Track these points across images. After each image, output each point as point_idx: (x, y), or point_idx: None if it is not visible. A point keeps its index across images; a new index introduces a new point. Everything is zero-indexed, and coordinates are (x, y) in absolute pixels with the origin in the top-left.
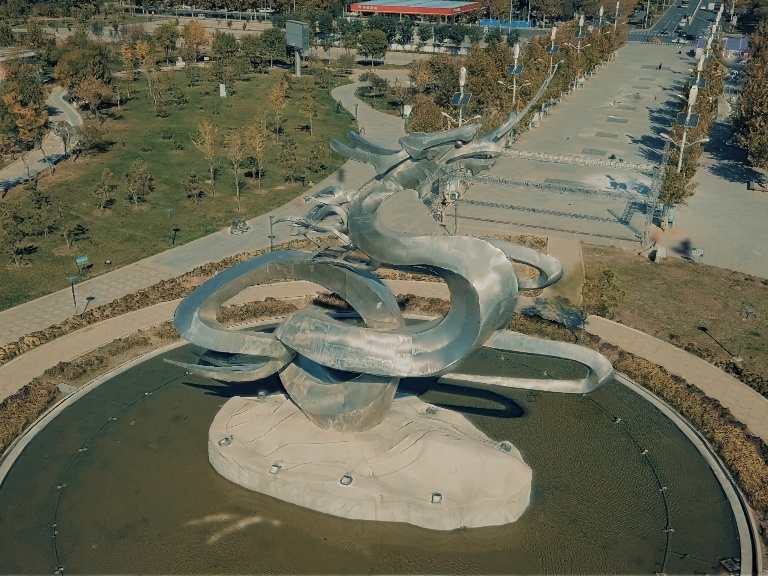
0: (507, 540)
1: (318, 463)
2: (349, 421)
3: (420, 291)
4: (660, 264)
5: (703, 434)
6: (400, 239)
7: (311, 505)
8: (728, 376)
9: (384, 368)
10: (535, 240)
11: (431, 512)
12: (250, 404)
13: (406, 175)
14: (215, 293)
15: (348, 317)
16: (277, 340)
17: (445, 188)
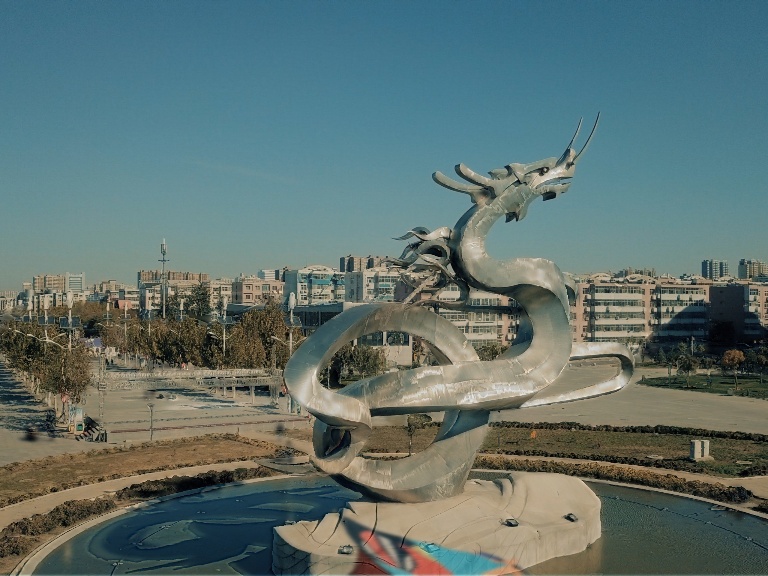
0: (600, 556)
1: (465, 525)
2: (458, 480)
3: (207, 471)
4: (342, 430)
5: (573, 475)
6: (502, 262)
7: (481, 573)
8: (516, 456)
9: (513, 390)
10: (224, 434)
11: (574, 533)
12: (308, 523)
13: (510, 199)
14: (327, 351)
15: (184, 496)
16: (369, 409)
17: (74, 417)
